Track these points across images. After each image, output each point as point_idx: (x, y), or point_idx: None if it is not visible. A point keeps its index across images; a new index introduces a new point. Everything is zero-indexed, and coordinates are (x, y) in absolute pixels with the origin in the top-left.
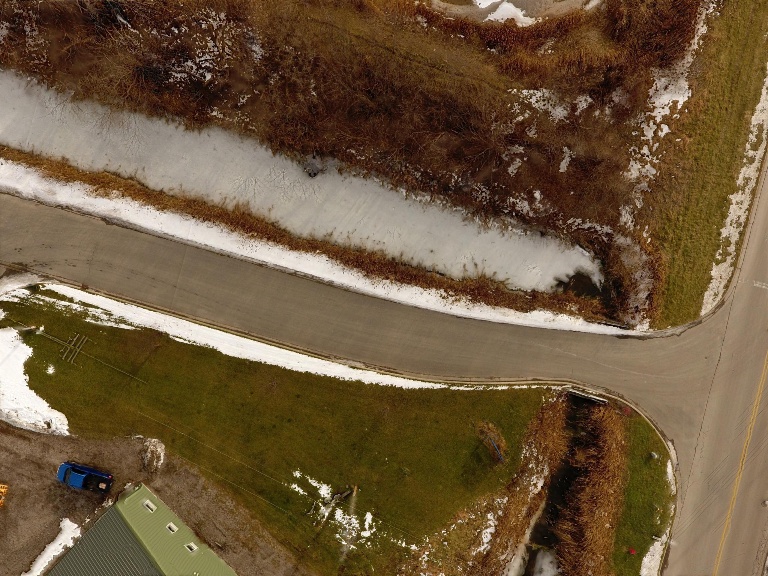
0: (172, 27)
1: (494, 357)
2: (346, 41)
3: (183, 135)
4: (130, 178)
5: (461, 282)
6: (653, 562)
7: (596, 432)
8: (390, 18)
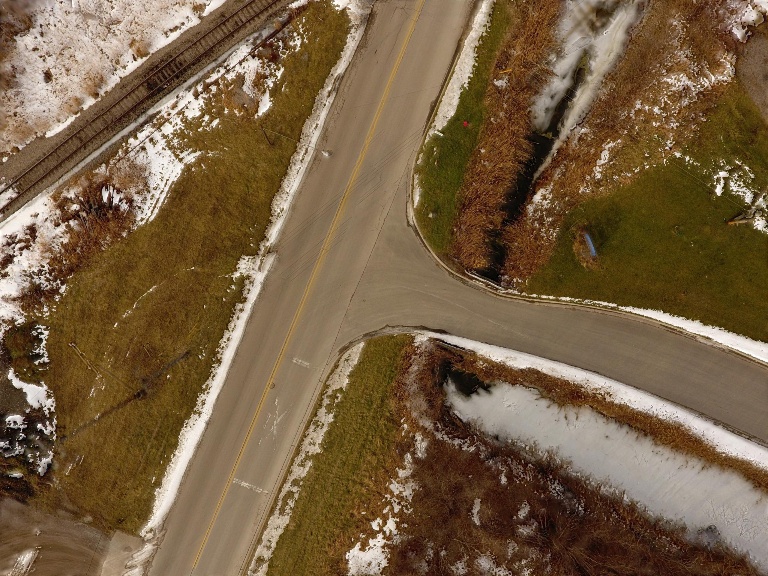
0: None
1: (568, 329)
2: None
3: None
4: None
5: None
6: (446, 110)
7: None
8: None
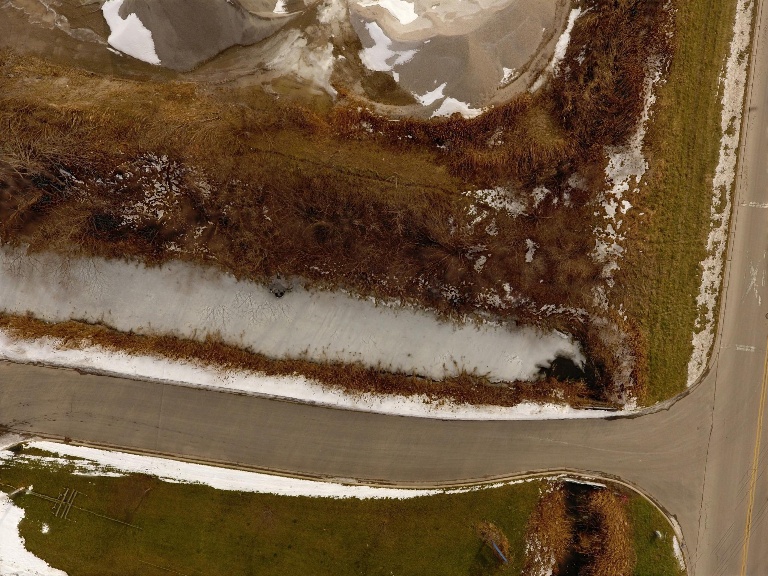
0: (116, 174)
1: (485, 455)
2: (292, 167)
3: (144, 273)
4: (97, 323)
5: (443, 382)
6: None
7: (597, 519)
8: (335, 128)
